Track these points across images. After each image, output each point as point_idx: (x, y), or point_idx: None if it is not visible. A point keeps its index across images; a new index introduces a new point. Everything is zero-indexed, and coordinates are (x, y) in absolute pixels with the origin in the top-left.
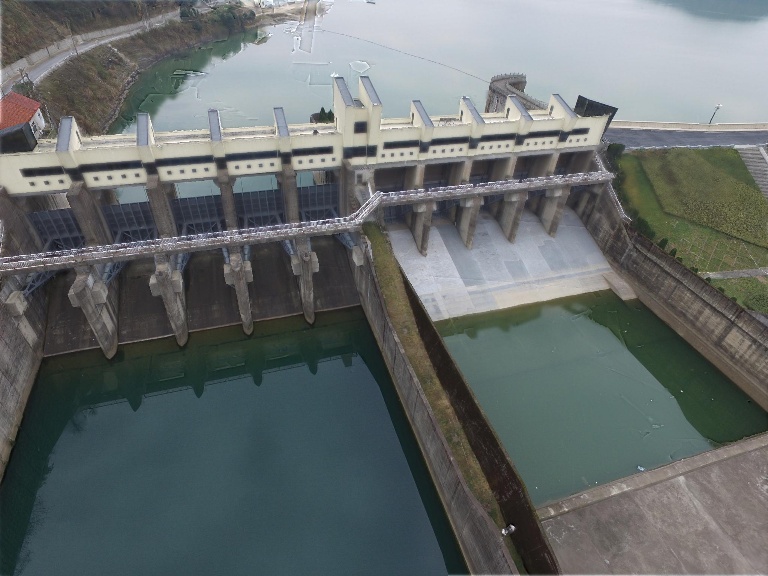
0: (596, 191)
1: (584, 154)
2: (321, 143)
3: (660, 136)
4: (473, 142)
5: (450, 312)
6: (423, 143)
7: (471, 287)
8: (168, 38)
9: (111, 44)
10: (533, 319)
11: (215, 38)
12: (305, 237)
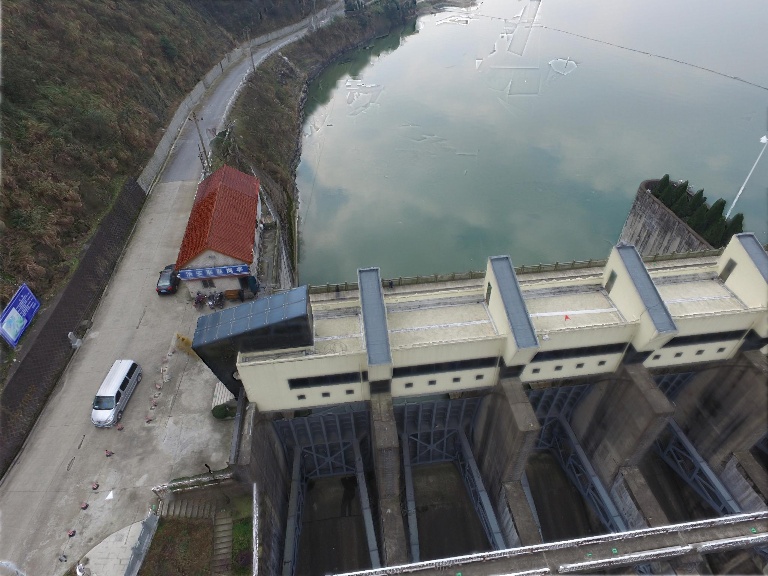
0: None
1: None
2: None
3: None
4: None
5: None
6: None
7: None
8: (333, 38)
9: (281, 52)
10: None
11: (377, 34)
12: None
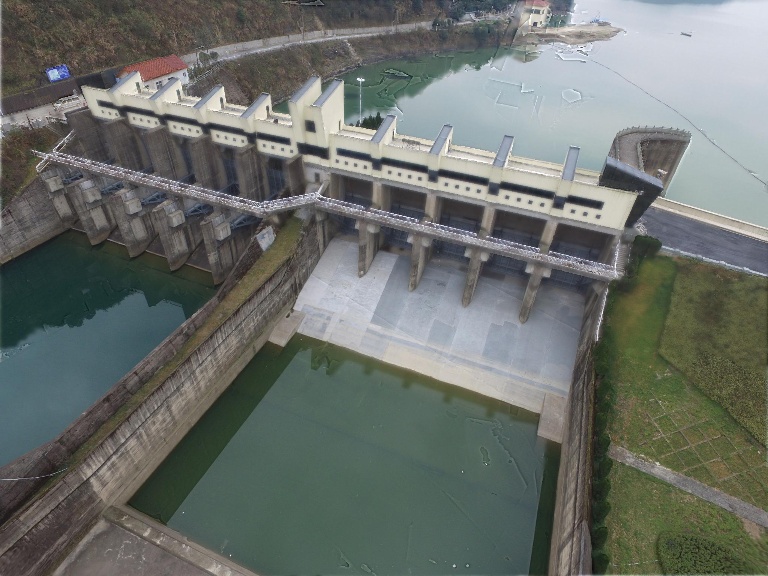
0: (596, 289)
1: (611, 238)
2: (280, 133)
3: None
4: (431, 174)
5: (332, 337)
6: (372, 159)
7: (375, 326)
8: (409, 42)
9: (348, 40)
10: (404, 389)
11: (460, 48)
12: (219, 206)
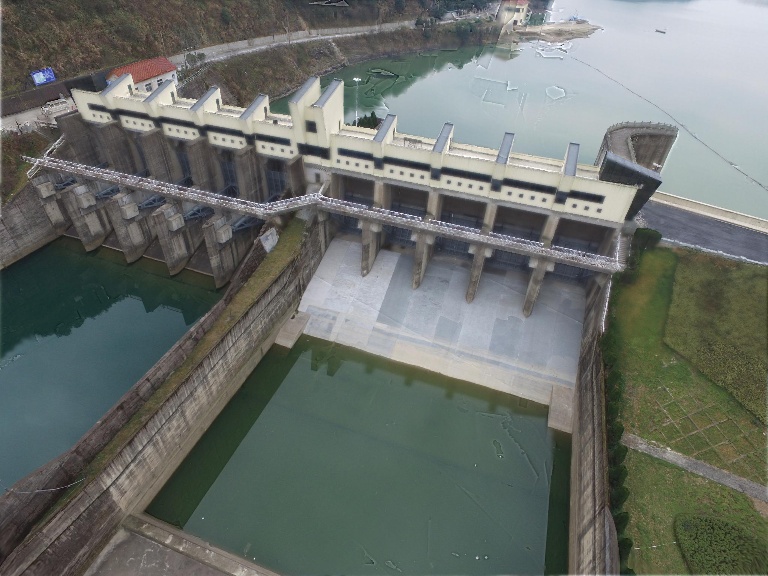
0: (598, 281)
1: (611, 231)
2: (280, 134)
3: (767, 245)
4: (433, 172)
5: (339, 337)
6: (374, 158)
7: (381, 324)
8: (393, 41)
9: (333, 39)
10: (414, 386)
11: (444, 47)
12: (220, 209)
